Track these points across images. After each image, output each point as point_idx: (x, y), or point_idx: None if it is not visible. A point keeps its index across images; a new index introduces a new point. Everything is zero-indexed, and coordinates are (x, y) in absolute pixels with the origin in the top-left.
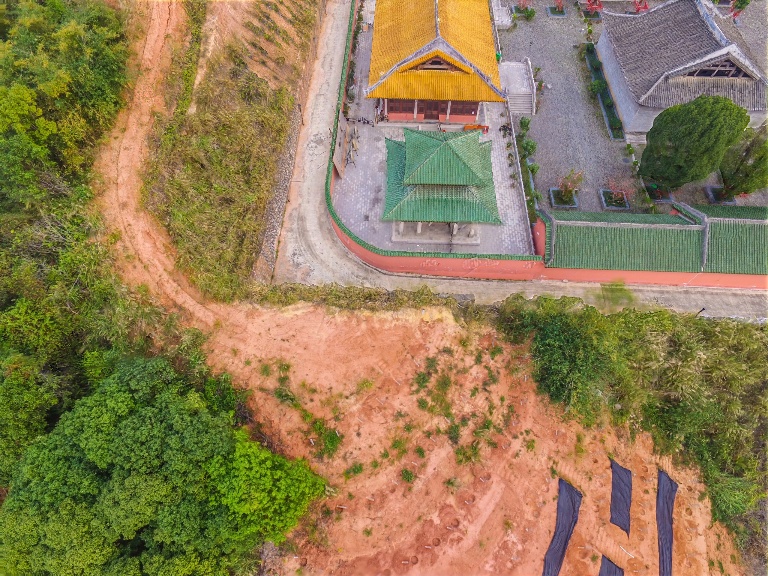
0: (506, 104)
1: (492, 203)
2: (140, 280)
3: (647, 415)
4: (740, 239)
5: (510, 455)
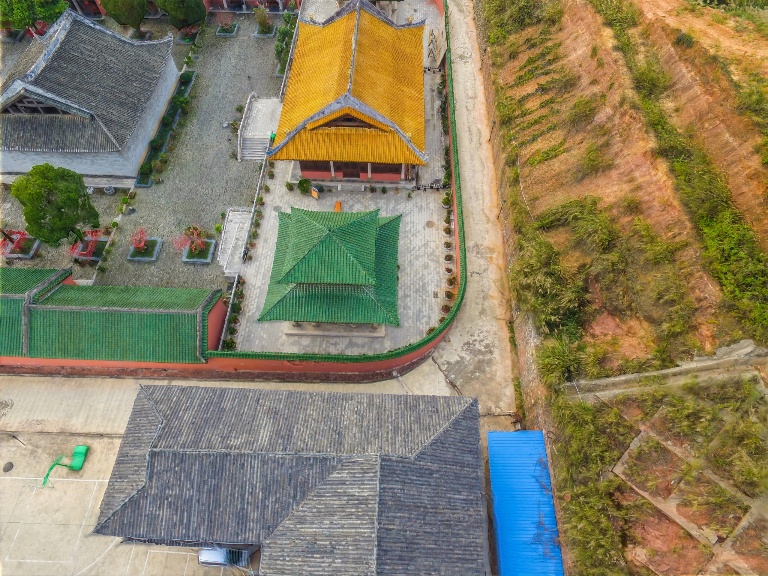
0: (285, 88)
1: None
2: None
3: None
4: None
5: None
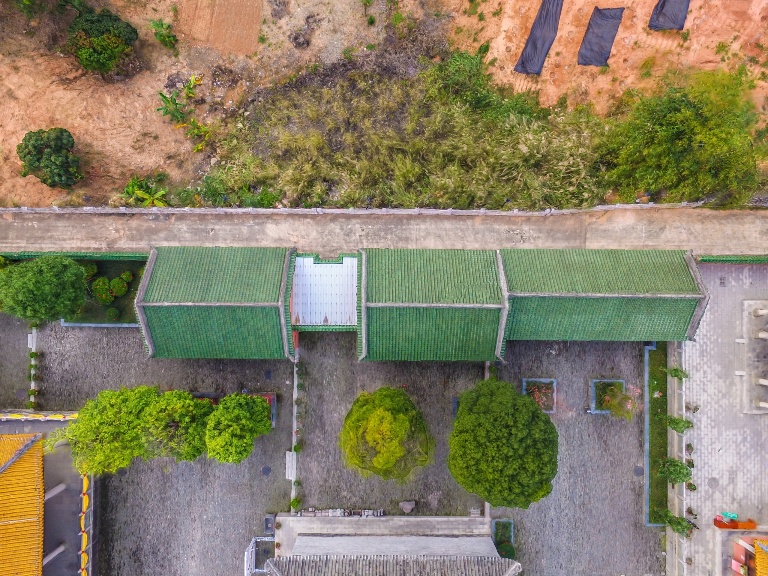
0: None
1: None
2: None
3: (543, 121)
4: (454, 286)
5: (742, 38)
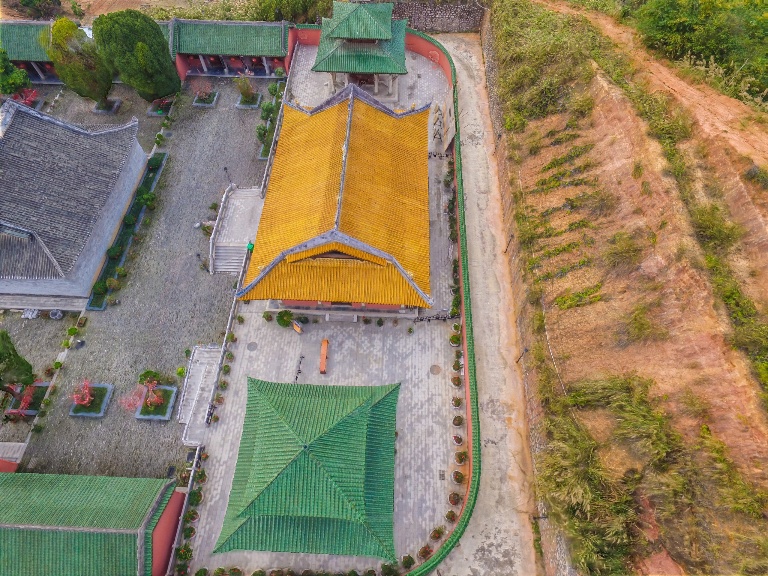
0: (267, 179)
1: (325, 28)
2: (559, 2)
3: None
4: None
5: None
